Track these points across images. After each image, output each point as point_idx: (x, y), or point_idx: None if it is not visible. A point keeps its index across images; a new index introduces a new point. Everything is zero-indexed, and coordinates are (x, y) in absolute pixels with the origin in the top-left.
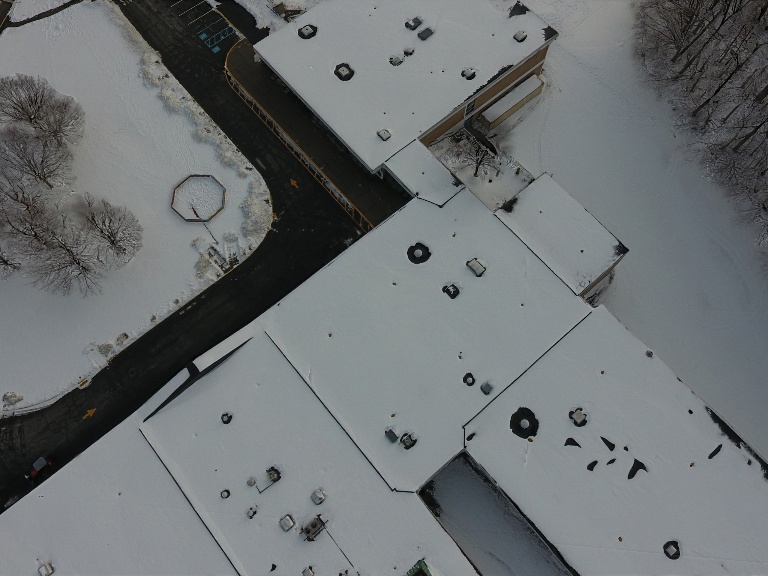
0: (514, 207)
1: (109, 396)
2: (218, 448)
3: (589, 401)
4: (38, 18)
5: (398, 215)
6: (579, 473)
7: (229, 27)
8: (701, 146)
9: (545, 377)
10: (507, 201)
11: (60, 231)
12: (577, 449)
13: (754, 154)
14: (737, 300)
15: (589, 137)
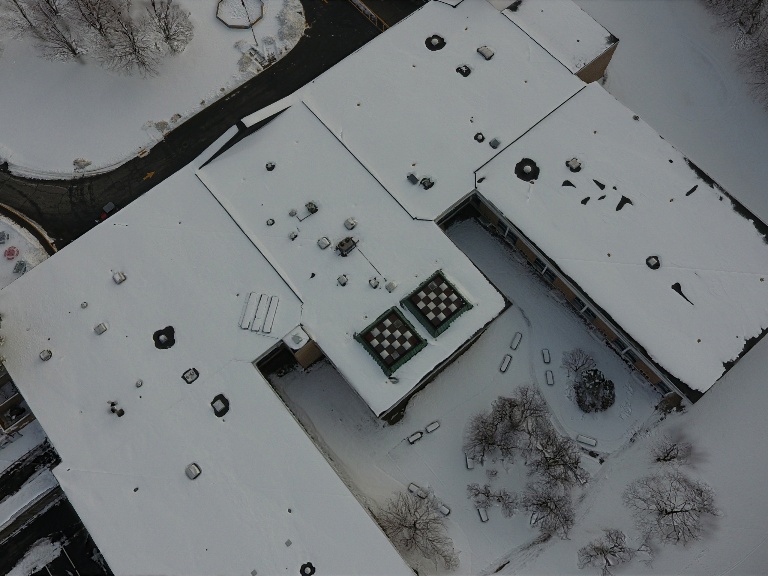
0: (519, 7)
1: (166, 162)
2: (263, 188)
3: (583, 153)
4: None
5: (417, 14)
6: (574, 206)
7: None
8: None
9: (545, 135)
10: None
11: None
12: (573, 189)
13: None
14: (715, 97)
15: None
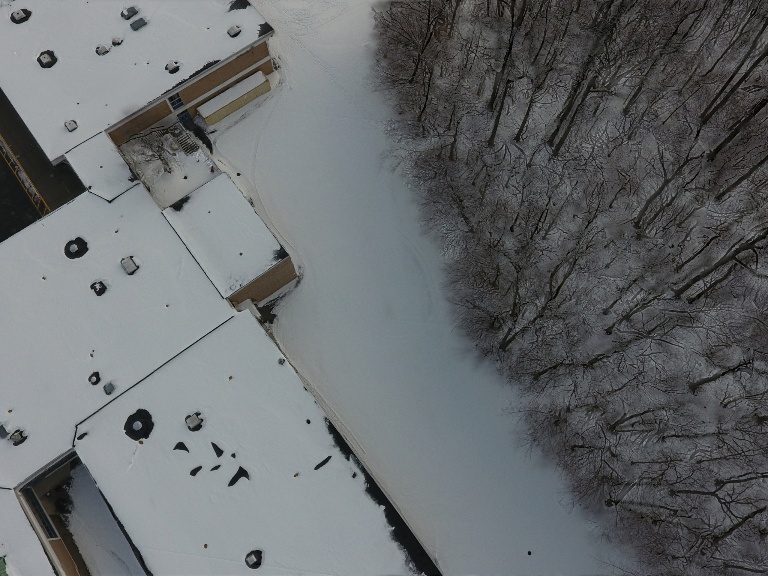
0: (184, 206)
1: None
2: None
3: (209, 406)
4: None
5: (65, 208)
6: (181, 478)
7: None
8: (402, 152)
9: (171, 380)
10: None
11: None
12: (185, 454)
13: (468, 163)
14: (419, 310)
15: (309, 137)
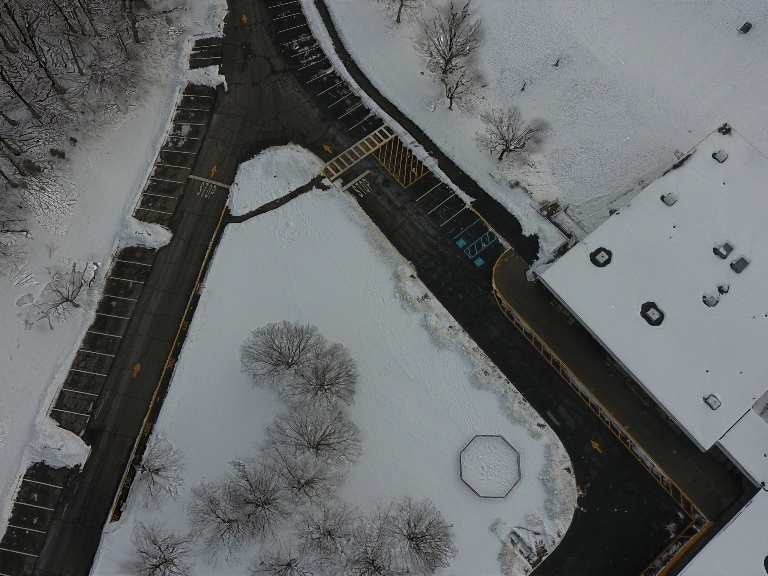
0: None
1: None
2: None
3: None
4: (263, 211)
5: (746, 513)
6: None
7: (489, 232)
8: None
9: None
10: None
11: (350, 525)
12: None
13: None
14: None
15: None
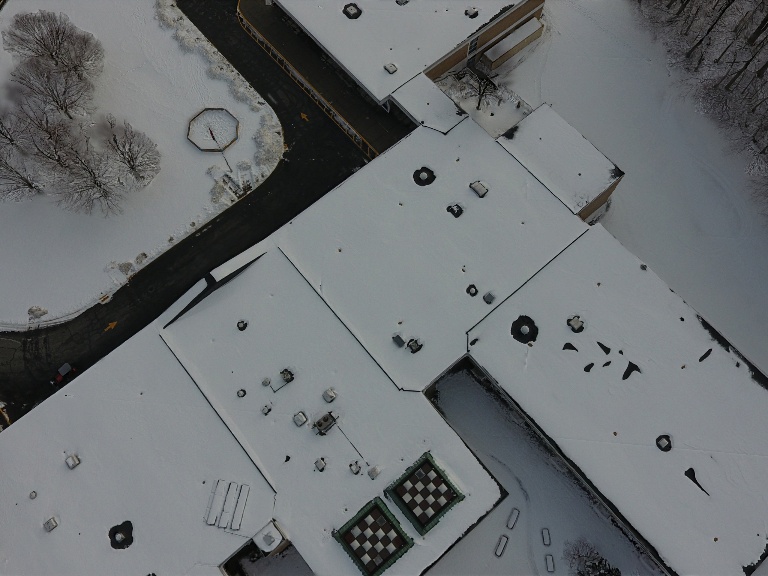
0: (515, 134)
1: (129, 310)
2: (234, 352)
3: (586, 310)
4: None
5: (404, 142)
6: (576, 374)
7: None
8: (694, 81)
9: (544, 288)
10: (508, 129)
11: (82, 157)
12: (574, 353)
13: (745, 92)
14: (728, 226)
15: (587, 77)
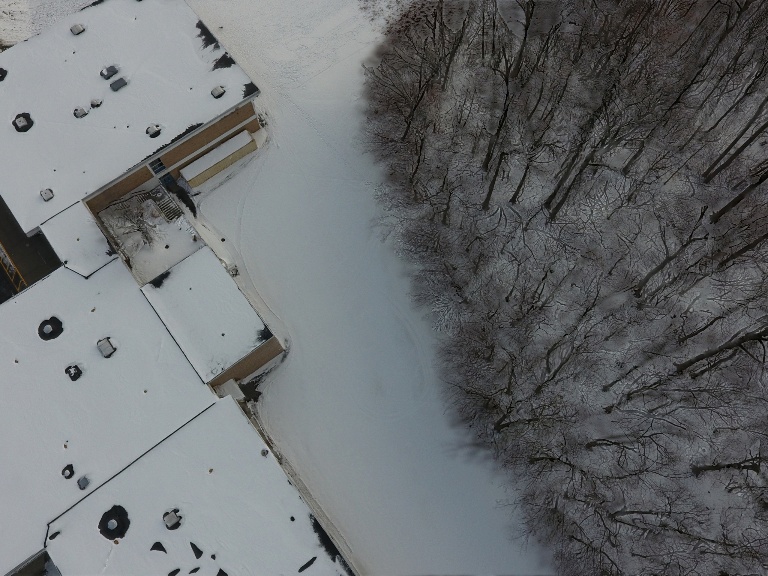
0: (164, 282)
1: None
2: None
3: (188, 502)
4: None
5: (39, 285)
6: None
7: None
8: (393, 220)
9: (149, 473)
10: None
11: None
12: (162, 555)
13: (462, 228)
14: (411, 387)
15: (297, 200)
